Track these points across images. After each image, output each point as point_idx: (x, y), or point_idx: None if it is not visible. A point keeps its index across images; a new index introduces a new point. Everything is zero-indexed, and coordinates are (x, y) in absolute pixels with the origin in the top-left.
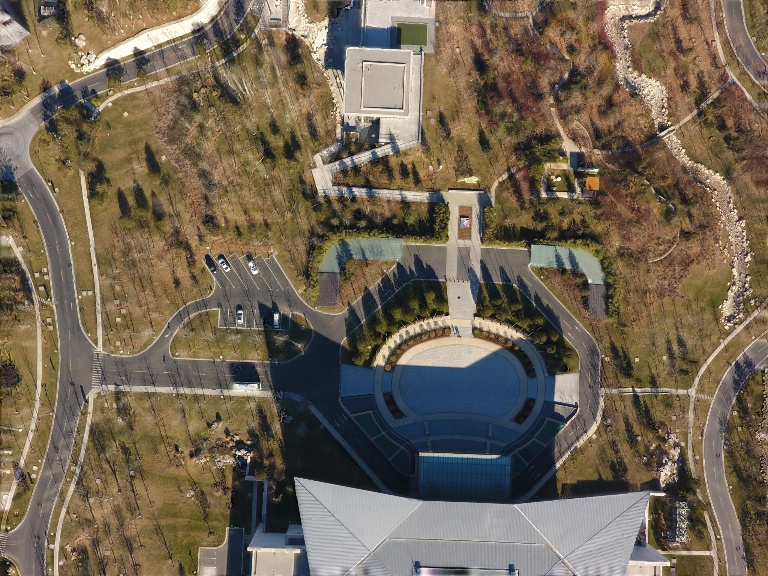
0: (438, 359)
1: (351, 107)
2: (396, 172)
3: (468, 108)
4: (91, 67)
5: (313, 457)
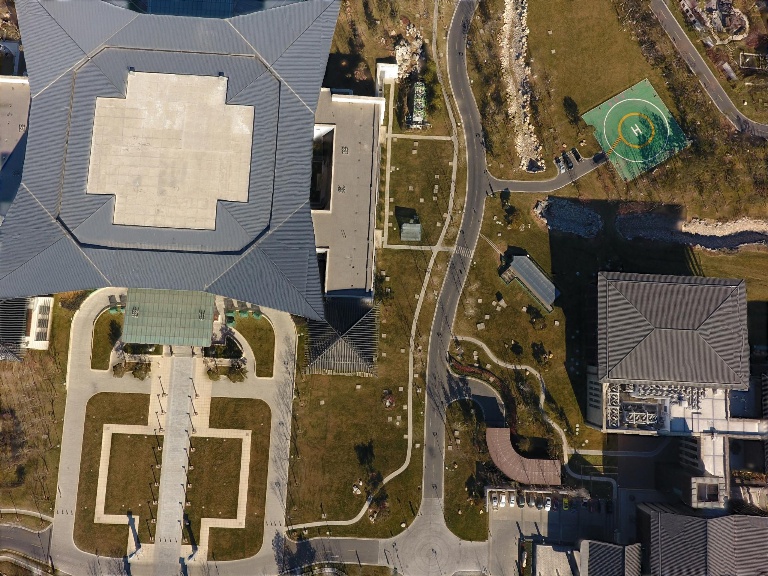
0: None
1: None
2: None
3: None
4: None
5: None
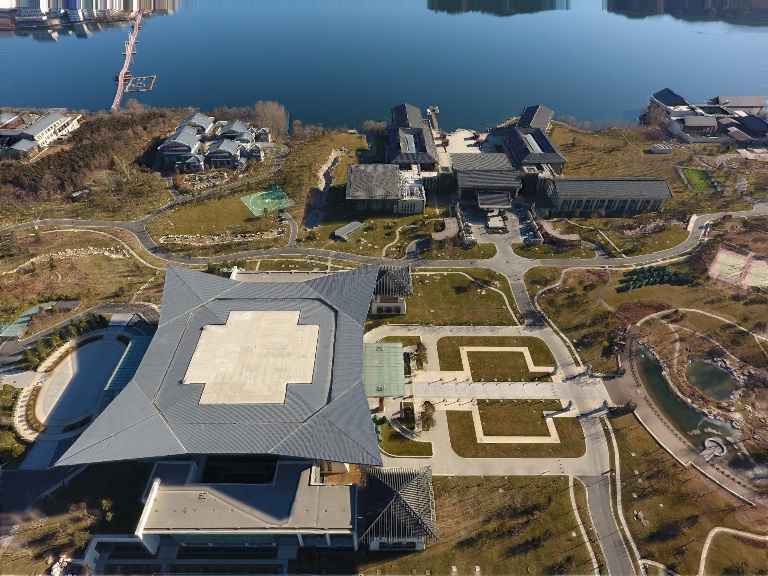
0: (56, 394)
1: None
2: None
3: None
4: None
5: (92, 490)
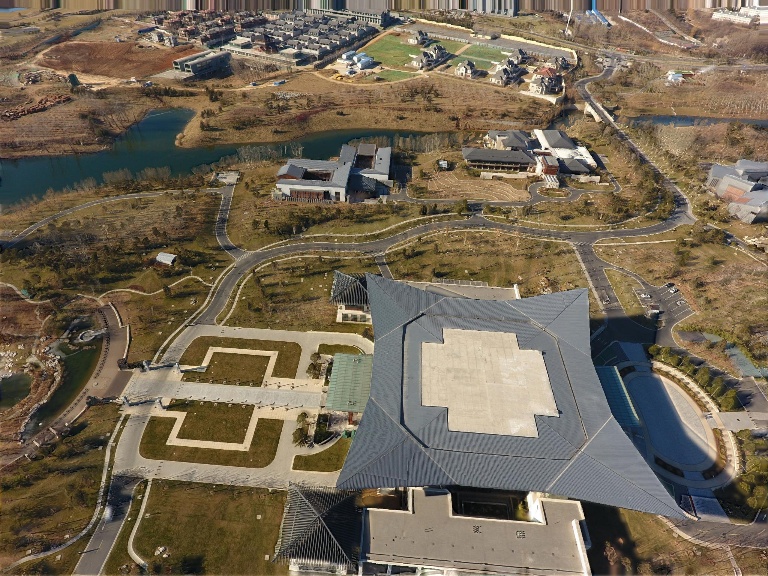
0: (679, 402)
1: None
2: None
3: None
4: (751, 243)
5: None
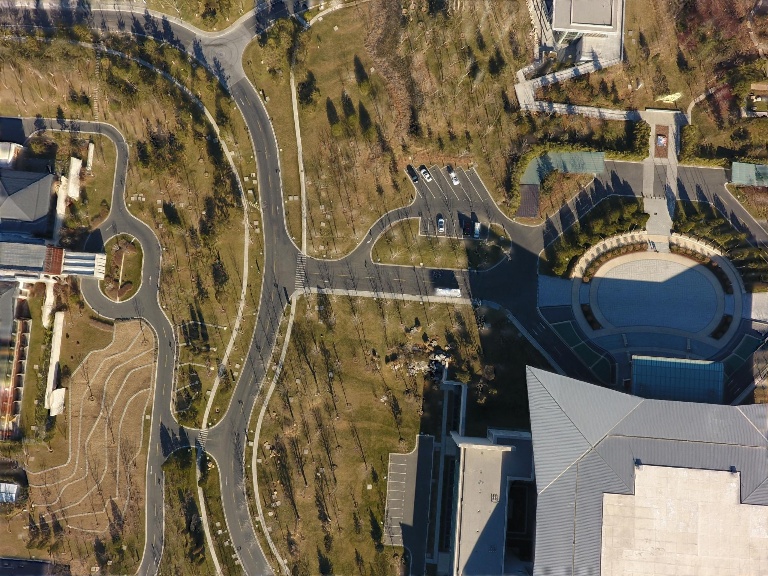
0: (635, 273)
1: (561, 22)
2: (596, 90)
3: (667, 30)
4: None
5: (512, 364)
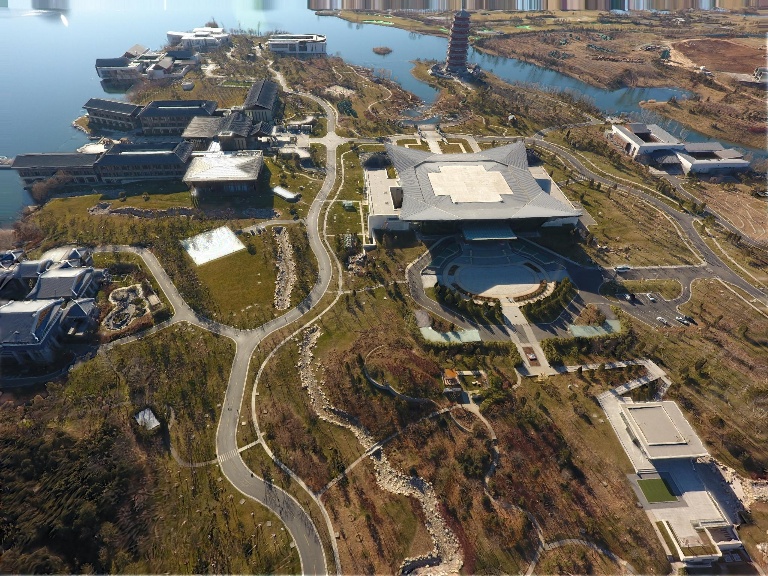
0: (516, 288)
1: (671, 406)
2: (602, 380)
3: (569, 432)
4: None
5: (565, 247)
